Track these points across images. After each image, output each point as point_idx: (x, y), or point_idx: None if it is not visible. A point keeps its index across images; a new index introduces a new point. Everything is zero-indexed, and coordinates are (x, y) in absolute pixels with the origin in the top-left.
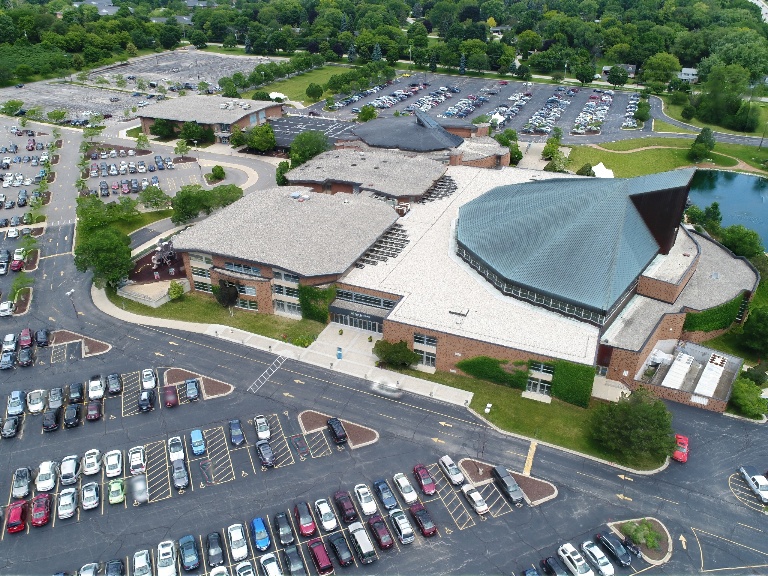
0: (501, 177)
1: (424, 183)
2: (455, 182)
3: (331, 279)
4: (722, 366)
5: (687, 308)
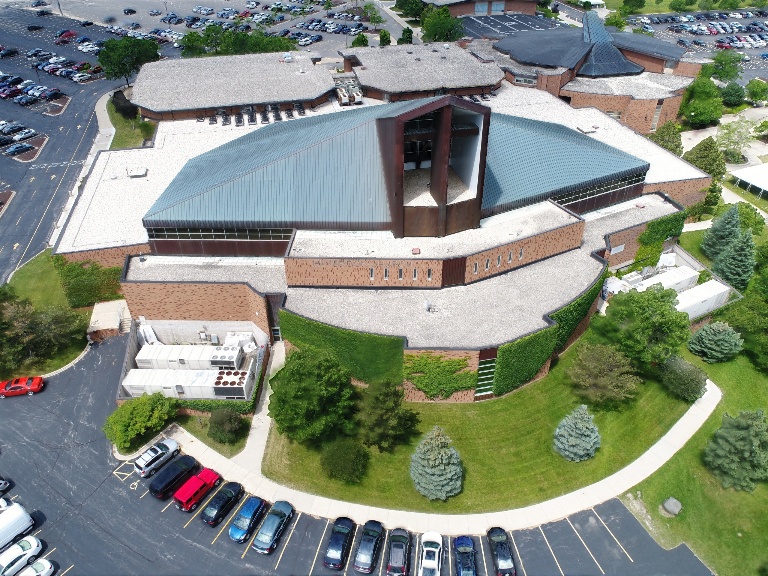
0: (551, 114)
1: (423, 85)
2: (484, 101)
3: (159, 117)
4: (216, 384)
5: (282, 297)
